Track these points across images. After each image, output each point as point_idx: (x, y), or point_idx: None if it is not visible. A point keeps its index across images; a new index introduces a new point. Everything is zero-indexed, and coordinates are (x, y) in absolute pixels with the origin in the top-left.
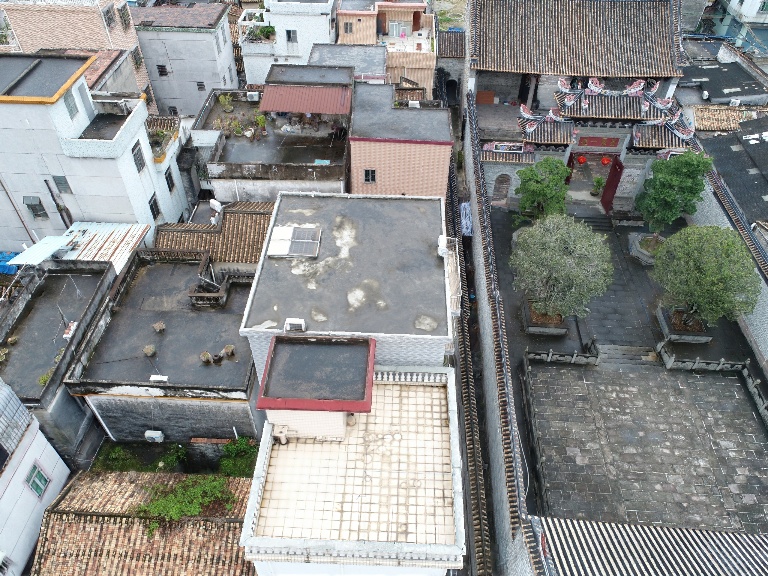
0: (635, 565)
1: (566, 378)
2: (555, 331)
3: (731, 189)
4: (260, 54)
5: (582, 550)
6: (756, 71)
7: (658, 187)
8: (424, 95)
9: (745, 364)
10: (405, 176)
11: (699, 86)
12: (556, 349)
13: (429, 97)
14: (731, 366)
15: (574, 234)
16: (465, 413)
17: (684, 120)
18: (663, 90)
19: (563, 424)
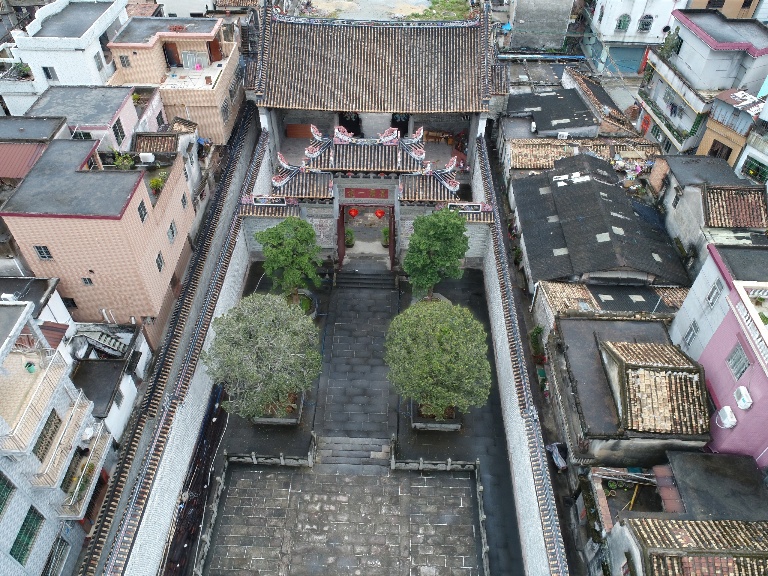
0: None
1: (269, 486)
2: (285, 421)
3: (525, 240)
4: (20, 93)
5: None
6: (589, 100)
7: (409, 250)
8: (175, 142)
9: (475, 464)
10: (84, 252)
11: (531, 116)
12: (281, 443)
13: (221, 136)
14: (462, 466)
15: (265, 321)
16: (86, 556)
17: (506, 156)
18: (477, 125)
19: (243, 550)
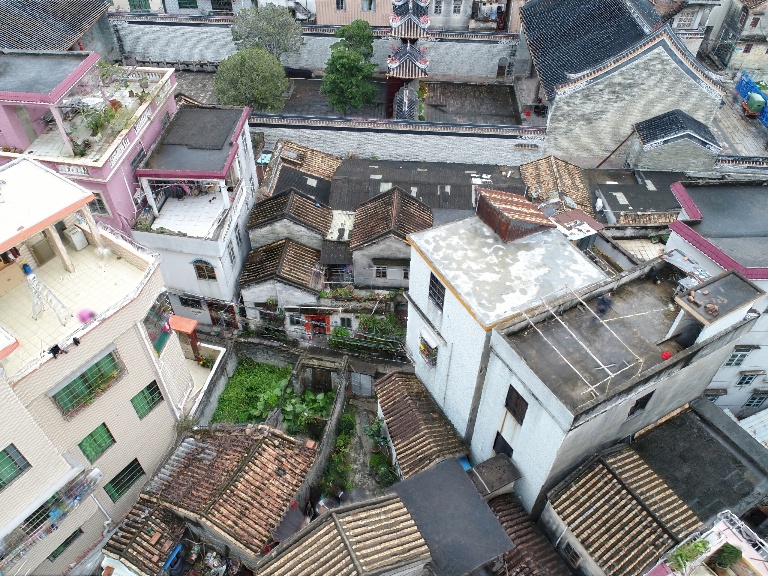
0: (70, 6)
1: None
2: None
3: None
4: None
5: (84, 2)
6: None
7: None
8: None
9: None
10: None
11: None
12: None
13: None
14: None
15: None
16: None
17: None
18: None
19: (190, 79)
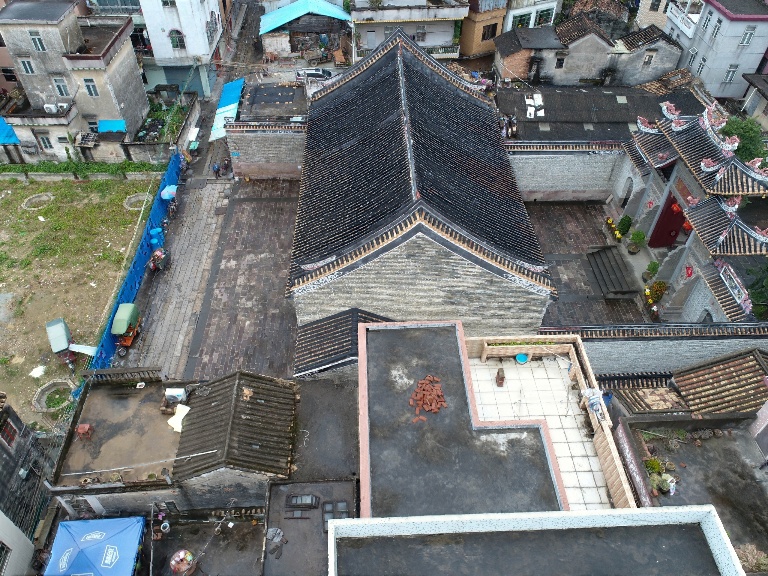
0: None
1: None
2: None
3: None
4: None
5: None
6: None
7: None
8: None
9: None
10: None
11: None
12: None
13: None
14: None
15: None
16: None
17: None
18: None
19: None
